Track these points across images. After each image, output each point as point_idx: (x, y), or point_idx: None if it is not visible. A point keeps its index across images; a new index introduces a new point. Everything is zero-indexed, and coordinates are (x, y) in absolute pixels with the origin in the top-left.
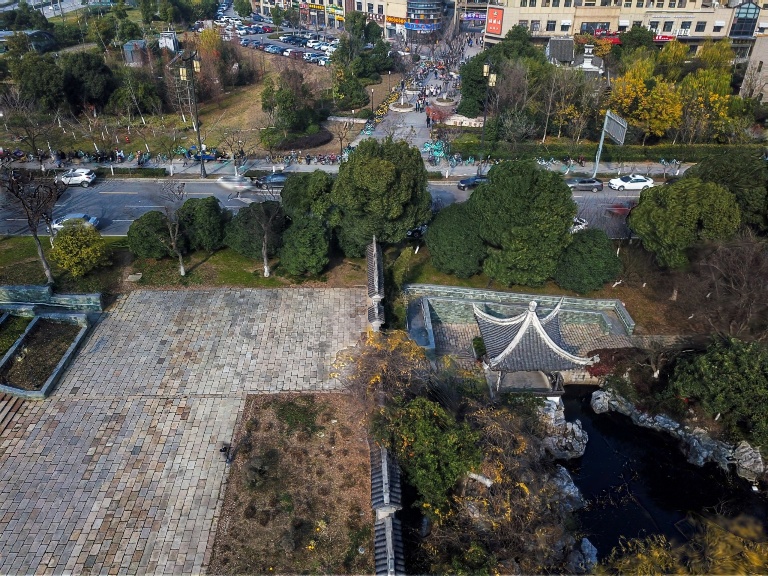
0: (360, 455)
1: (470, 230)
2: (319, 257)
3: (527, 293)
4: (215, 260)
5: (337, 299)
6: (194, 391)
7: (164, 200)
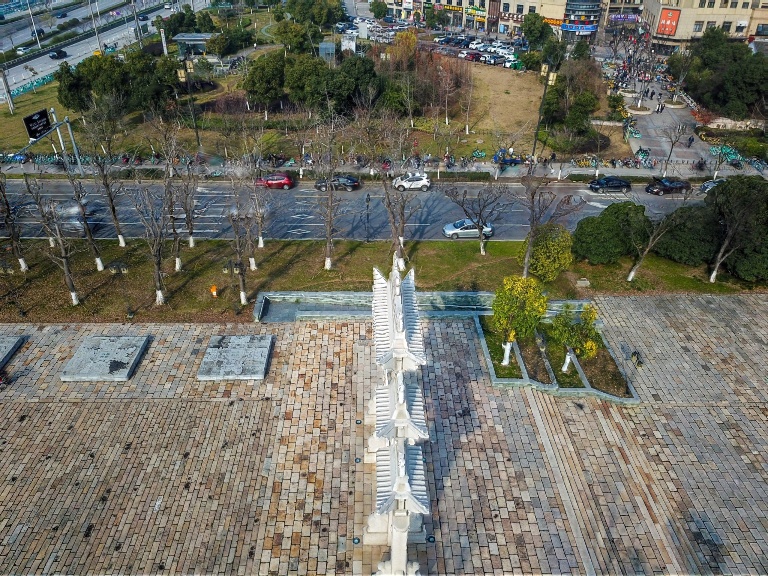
0: None
1: None
2: None
3: None
4: (645, 265)
5: None
6: None
7: (517, 204)
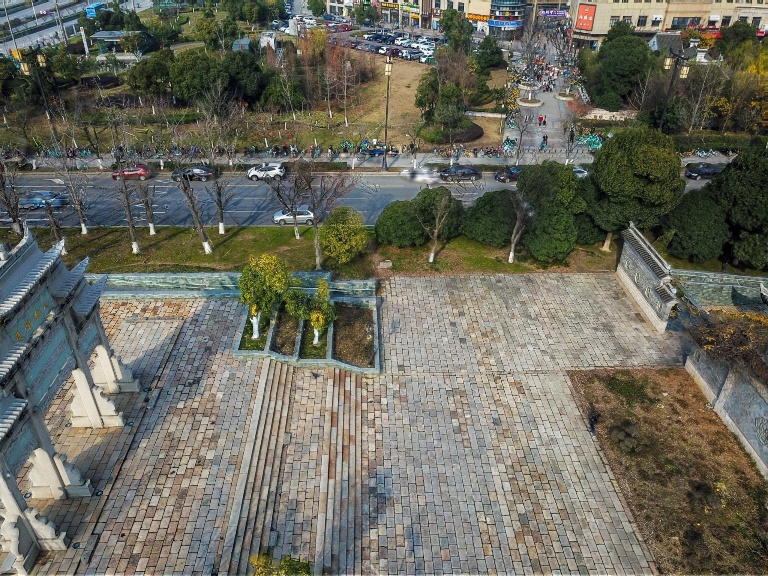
0: (711, 424)
1: (717, 216)
2: (570, 243)
3: (763, 276)
4: (453, 248)
5: (591, 283)
6: (514, 368)
7: (362, 192)
